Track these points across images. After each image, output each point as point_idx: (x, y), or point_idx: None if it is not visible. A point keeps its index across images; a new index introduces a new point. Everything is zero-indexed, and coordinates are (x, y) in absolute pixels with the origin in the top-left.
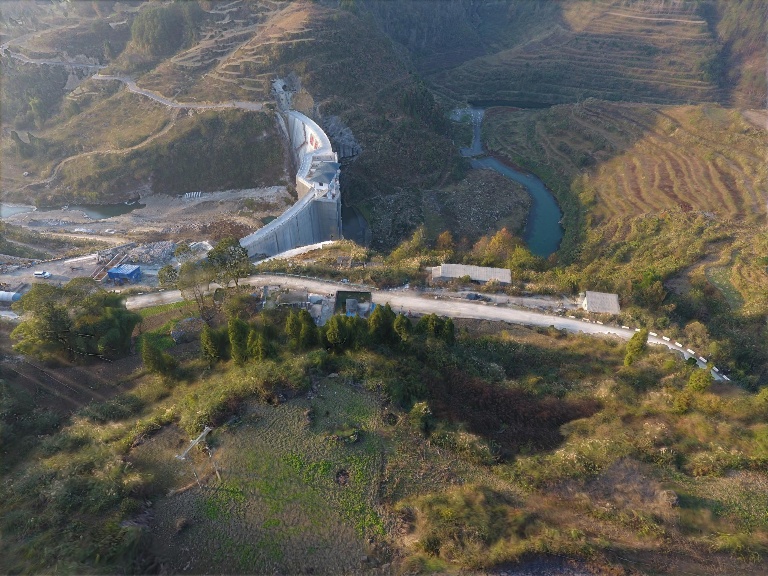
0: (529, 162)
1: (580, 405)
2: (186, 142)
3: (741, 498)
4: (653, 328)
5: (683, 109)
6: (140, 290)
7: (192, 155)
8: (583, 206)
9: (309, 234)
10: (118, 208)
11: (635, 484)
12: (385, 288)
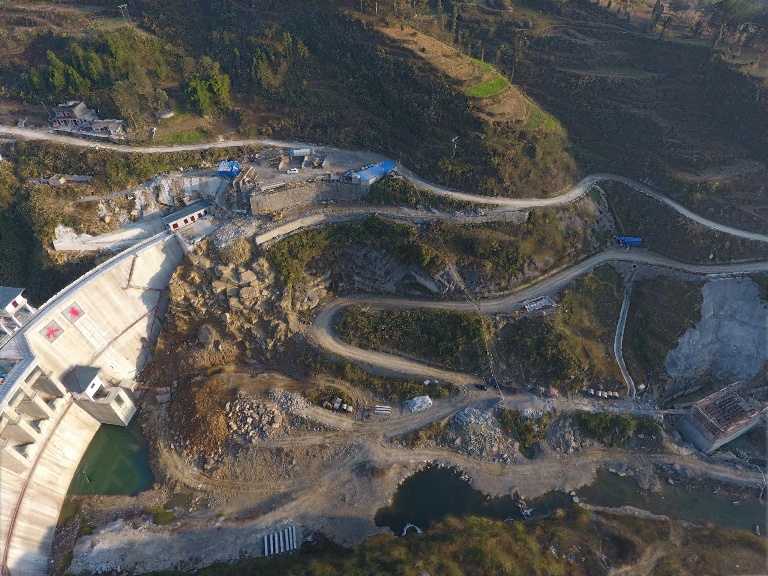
0: None
1: (8, 55)
2: None
3: None
4: None
5: None
6: (208, 149)
7: None
8: None
9: None
10: (428, 515)
11: (20, 31)
12: None
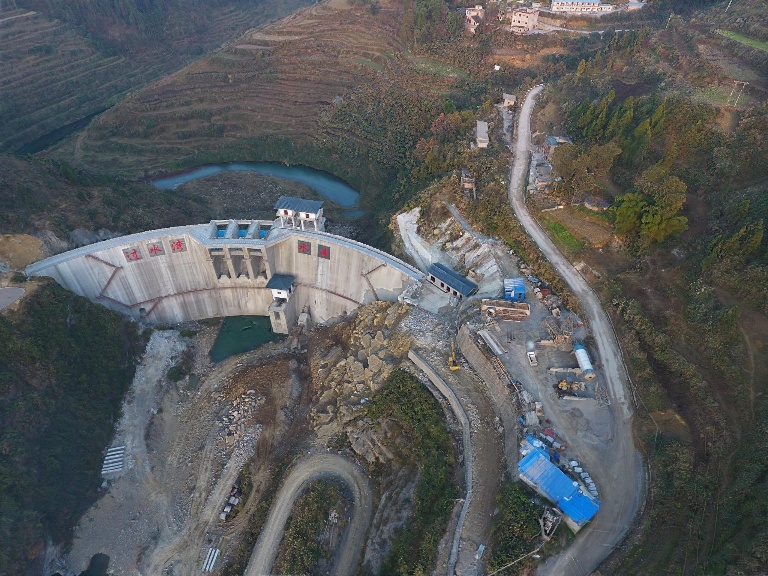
0: (185, 161)
1: (617, 81)
2: (4, 432)
3: (651, 57)
4: (526, 89)
5: (203, 65)
6: None
7: (37, 432)
8: (286, 144)
9: None
10: None
11: None
12: None
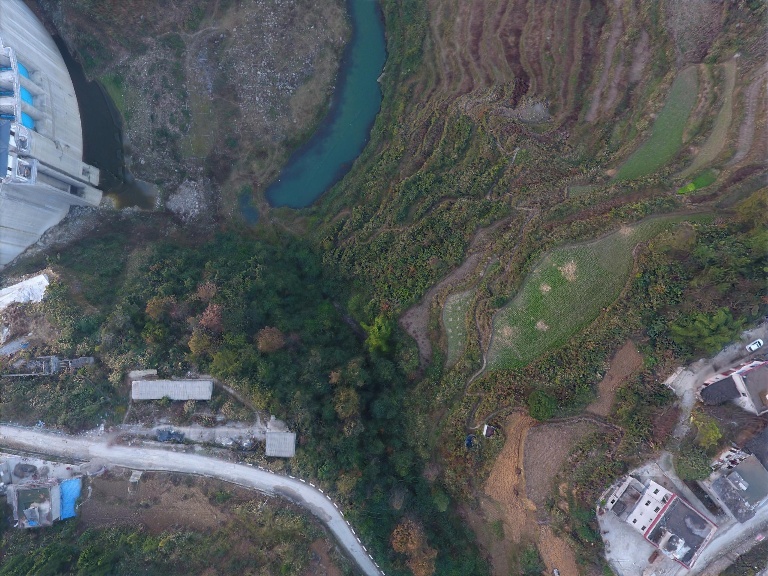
0: None
1: None
2: None
3: None
4: (313, 480)
5: None
6: None
7: None
8: (405, 59)
9: (31, 211)
10: None
11: None
12: (81, 432)
